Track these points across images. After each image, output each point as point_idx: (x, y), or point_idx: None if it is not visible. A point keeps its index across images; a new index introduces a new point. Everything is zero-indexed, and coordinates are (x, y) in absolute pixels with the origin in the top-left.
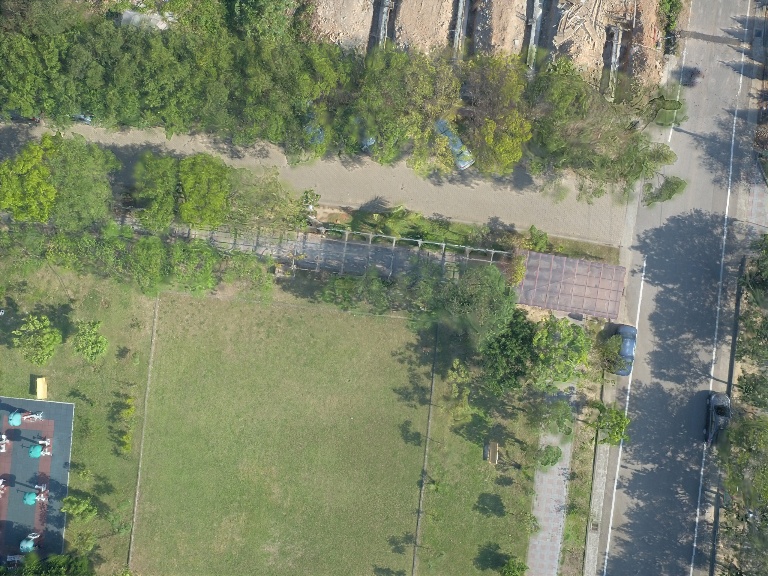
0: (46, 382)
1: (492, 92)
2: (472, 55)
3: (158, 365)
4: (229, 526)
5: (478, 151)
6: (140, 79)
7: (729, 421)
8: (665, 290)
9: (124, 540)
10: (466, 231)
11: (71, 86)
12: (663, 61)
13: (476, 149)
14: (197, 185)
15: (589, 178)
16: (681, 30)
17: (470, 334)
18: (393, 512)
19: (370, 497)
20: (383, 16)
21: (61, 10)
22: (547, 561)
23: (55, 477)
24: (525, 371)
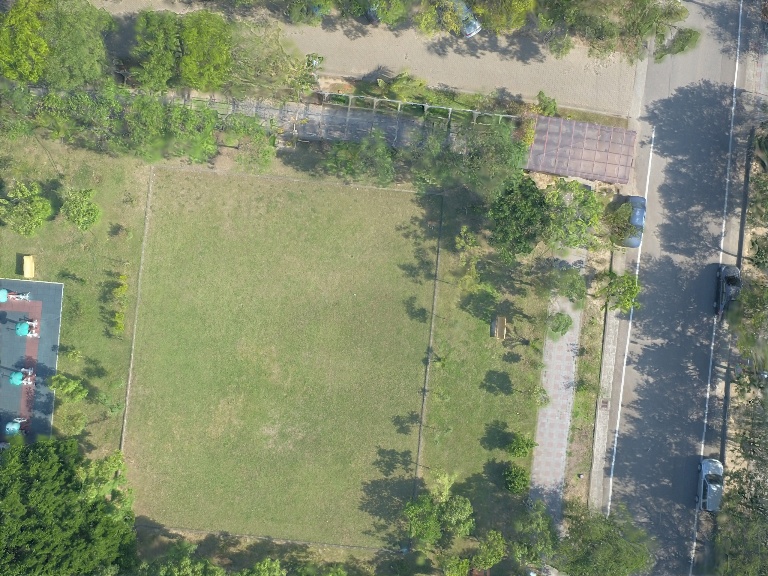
0: (33, 260)
1: None
2: None
3: (152, 242)
4: (227, 408)
5: (486, 6)
6: None
7: (740, 291)
8: (674, 162)
9: (116, 425)
10: (472, 102)
11: None
12: None
13: (482, 14)
14: (195, 38)
15: (597, 47)
16: None
17: (476, 207)
18: (398, 391)
19: (374, 376)
20: None
21: None
22: (556, 440)
23: (43, 360)
24: (535, 232)
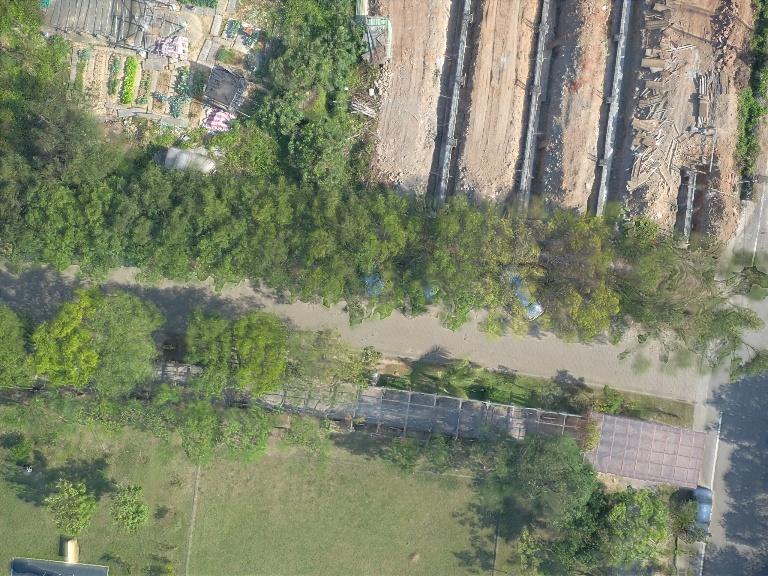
0: (78, 544)
1: (573, 257)
2: (539, 195)
3: (200, 525)
4: None
5: (555, 315)
6: (191, 234)
7: None
8: (741, 449)
9: None
10: (533, 385)
11: (116, 242)
12: (740, 207)
13: None
14: (253, 351)
15: (663, 330)
16: (759, 175)
17: None
18: None
19: None
20: (445, 154)
21: (102, 152)
22: None
23: None
24: (603, 550)
